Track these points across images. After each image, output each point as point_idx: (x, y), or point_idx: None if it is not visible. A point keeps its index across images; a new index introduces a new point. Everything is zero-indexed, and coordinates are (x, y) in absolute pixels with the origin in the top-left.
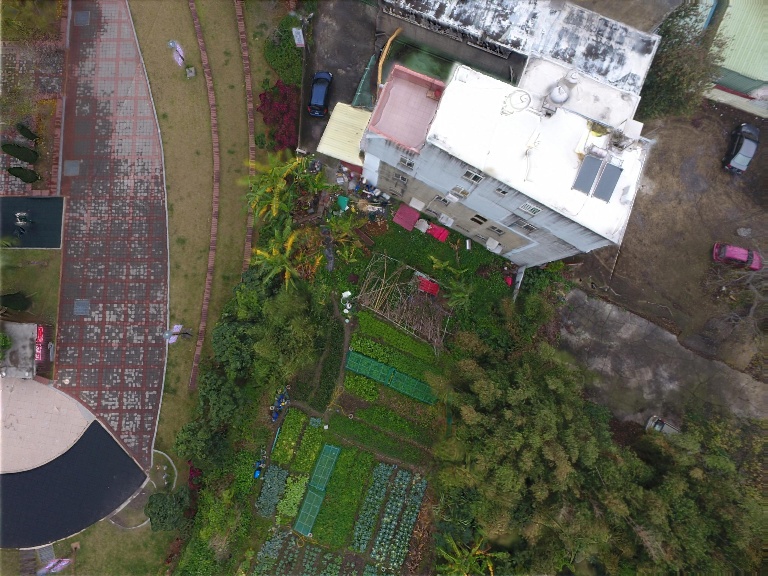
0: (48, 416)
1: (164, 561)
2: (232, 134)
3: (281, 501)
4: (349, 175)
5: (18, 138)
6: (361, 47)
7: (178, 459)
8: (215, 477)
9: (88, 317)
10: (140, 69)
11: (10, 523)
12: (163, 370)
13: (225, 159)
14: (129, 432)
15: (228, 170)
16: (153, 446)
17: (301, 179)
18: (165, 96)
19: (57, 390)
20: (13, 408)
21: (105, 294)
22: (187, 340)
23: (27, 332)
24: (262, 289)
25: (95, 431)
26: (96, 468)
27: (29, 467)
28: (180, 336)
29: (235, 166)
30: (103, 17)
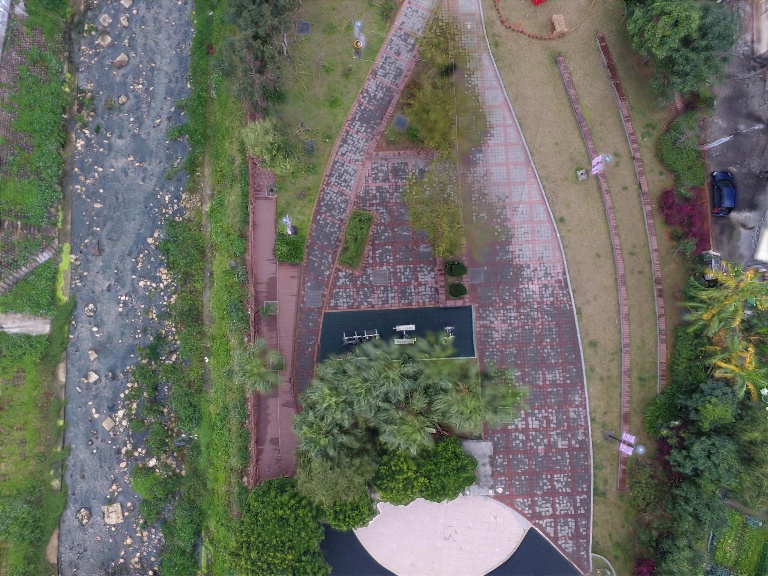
0: (486, 526)
1: None
2: (631, 235)
3: None
4: (753, 273)
5: (422, 248)
6: (748, 144)
7: (616, 561)
8: None
9: (512, 425)
10: (531, 173)
11: None
12: (590, 474)
13: (627, 261)
14: (565, 537)
15: (632, 272)
16: (591, 550)
17: (719, 281)
18: (560, 200)
19: (492, 499)
20: (451, 519)
21: (525, 401)
22: (610, 443)
23: (485, 449)
24: (734, 402)
25: (533, 538)
26: (538, 575)
27: None
28: (603, 439)
29: (637, 267)
30: (488, 122)
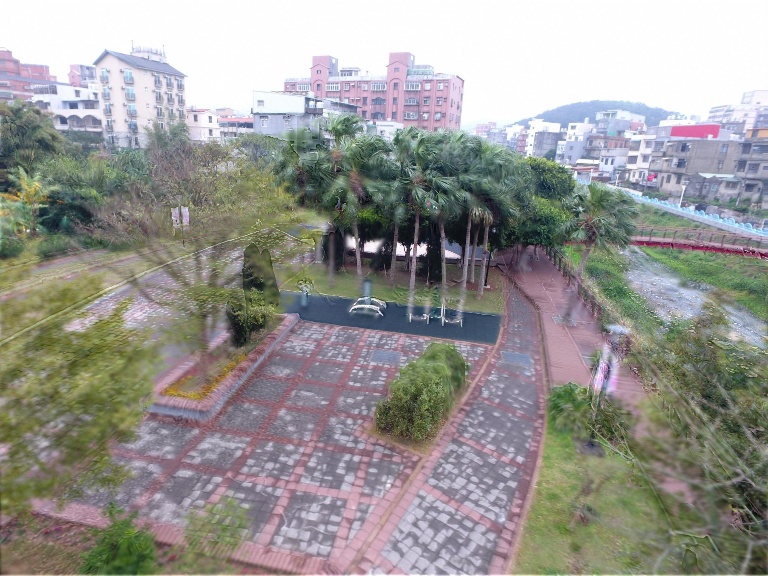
0: None
1: None
2: None
3: None
4: None
5: (285, 371)
6: None
7: None
8: None
9: (275, 262)
10: None
11: None
12: None
13: None
14: None
15: None
16: None
17: None
18: None
19: None
20: None
21: None
22: (188, 246)
23: None
24: None
25: None
26: None
27: None
28: None
29: None
30: None
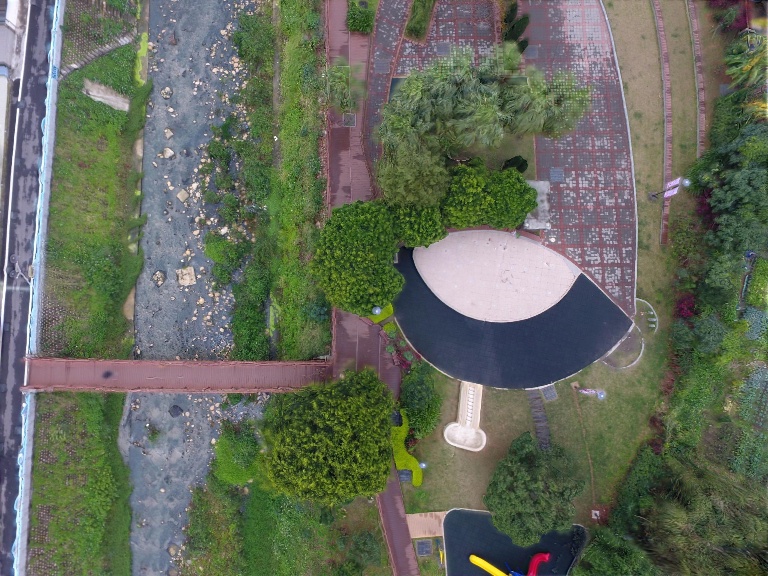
0: (539, 271)
1: (659, 394)
2: (673, 20)
3: (760, 338)
4: None
5: (482, 25)
6: None
7: (658, 306)
8: (706, 317)
9: (564, 183)
10: None
11: (516, 366)
12: (635, 229)
13: (670, 42)
14: (612, 283)
15: (674, 52)
16: (635, 295)
17: None
18: None
19: (545, 247)
20: (507, 264)
21: (576, 163)
22: (653, 202)
23: (543, 188)
24: None
25: (583, 283)
26: (587, 315)
27: (527, 316)
28: (646, 199)
29: (679, 48)
30: None
